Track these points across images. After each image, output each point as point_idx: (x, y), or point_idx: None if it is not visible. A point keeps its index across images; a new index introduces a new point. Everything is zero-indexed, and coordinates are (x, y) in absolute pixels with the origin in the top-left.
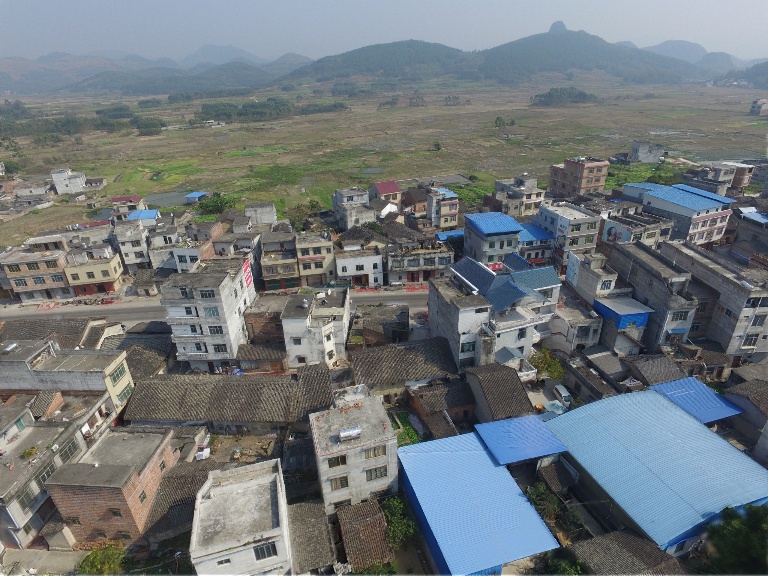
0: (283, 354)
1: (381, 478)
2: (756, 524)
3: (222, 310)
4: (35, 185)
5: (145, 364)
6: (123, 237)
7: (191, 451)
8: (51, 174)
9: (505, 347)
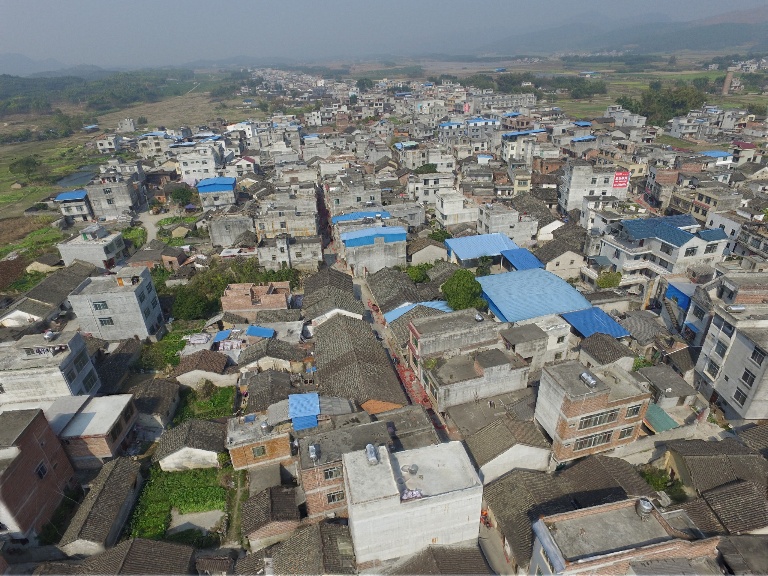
0: (578, 220)
1: (487, 233)
2: None
3: (571, 180)
4: None
5: (547, 195)
6: (662, 156)
7: None
8: None
9: (605, 256)
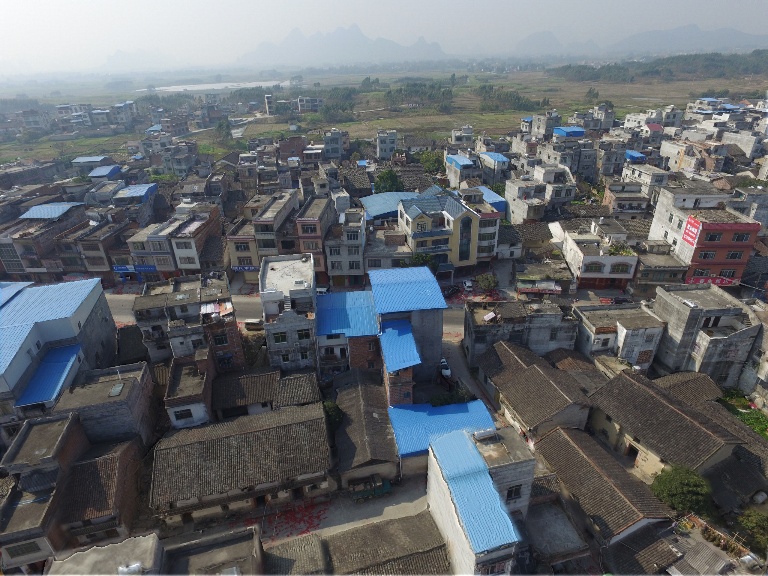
0: None
1: None
2: (393, 181)
3: None
4: None
5: None
6: None
7: None
8: None
9: None
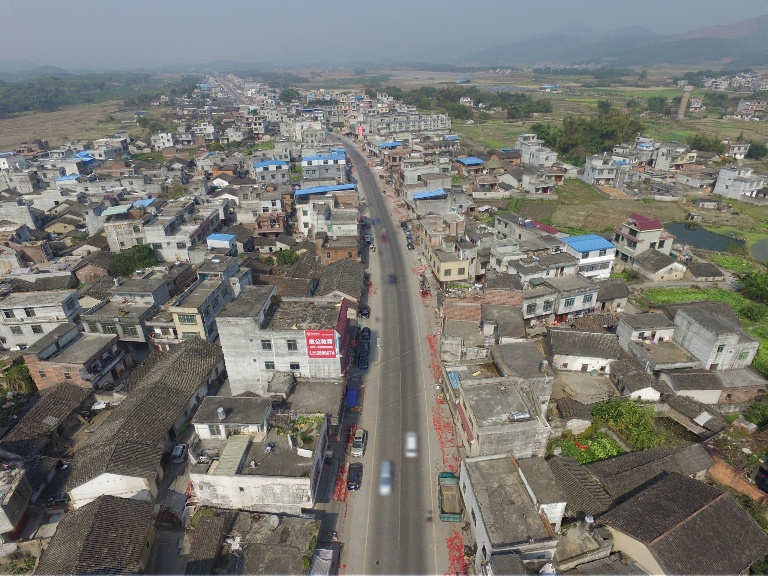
0: None
1: None
2: None
3: None
4: (700, 175)
5: None
6: (494, 249)
7: (107, 396)
8: (721, 169)
9: None
